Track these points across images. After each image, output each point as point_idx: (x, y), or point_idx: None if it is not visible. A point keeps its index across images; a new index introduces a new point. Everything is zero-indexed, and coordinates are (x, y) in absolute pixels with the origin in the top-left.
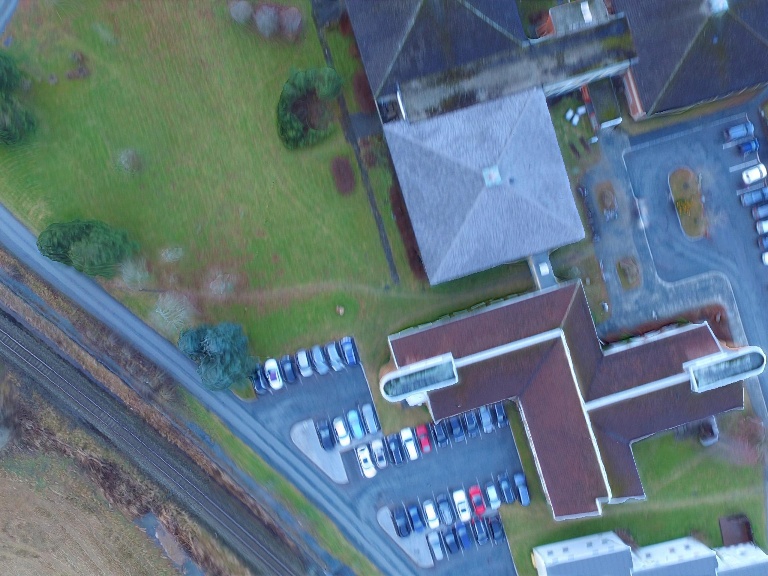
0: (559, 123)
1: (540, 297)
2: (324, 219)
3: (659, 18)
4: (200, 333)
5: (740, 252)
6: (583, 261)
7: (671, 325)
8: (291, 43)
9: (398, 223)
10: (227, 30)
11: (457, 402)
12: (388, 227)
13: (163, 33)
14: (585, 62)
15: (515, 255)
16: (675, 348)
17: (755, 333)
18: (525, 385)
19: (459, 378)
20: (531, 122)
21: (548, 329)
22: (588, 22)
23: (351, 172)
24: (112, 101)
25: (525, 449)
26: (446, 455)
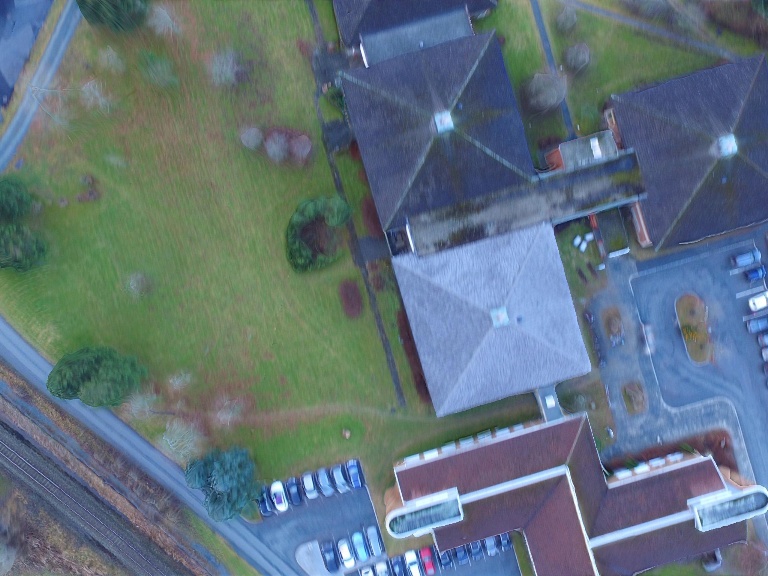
0: (567, 248)
1: (546, 430)
2: (331, 342)
3: (668, 156)
4: (207, 467)
5: (745, 378)
6: (589, 386)
7: (676, 455)
8: (301, 167)
9: (405, 347)
10: (237, 153)
11: (462, 535)
12: (395, 350)
13: (173, 156)
14: (594, 197)
15: (521, 388)
16: (680, 483)
17: (759, 458)
18: (530, 518)
19: (464, 513)
20: (539, 258)
21: (553, 466)
22: (597, 158)
23: (359, 296)
24: (122, 223)
25: (528, 572)
26: None
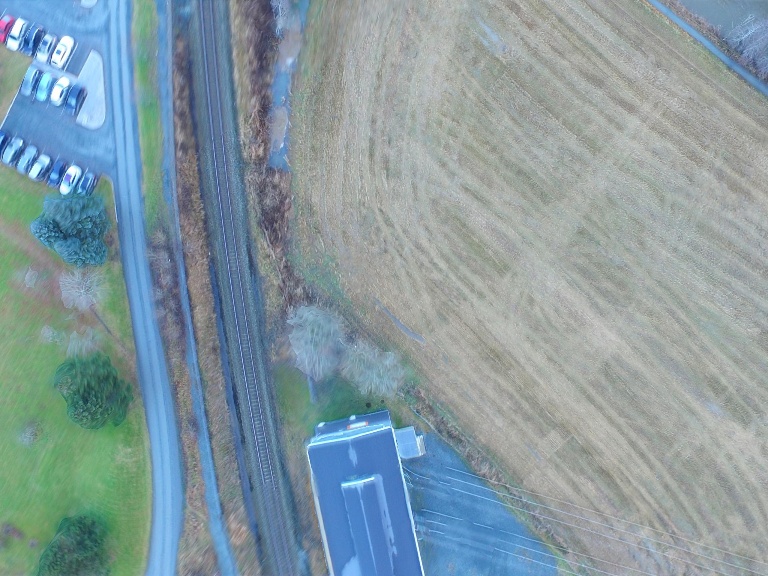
0: None
1: None
2: None
3: None
4: None
5: None
6: None
7: None
8: None
9: None
10: None
11: None
12: None
13: None
14: None
15: None
16: None
17: None
18: None
19: None
20: None
21: None
22: None
23: None
24: (7, 490)
25: None
26: (2, 2)
